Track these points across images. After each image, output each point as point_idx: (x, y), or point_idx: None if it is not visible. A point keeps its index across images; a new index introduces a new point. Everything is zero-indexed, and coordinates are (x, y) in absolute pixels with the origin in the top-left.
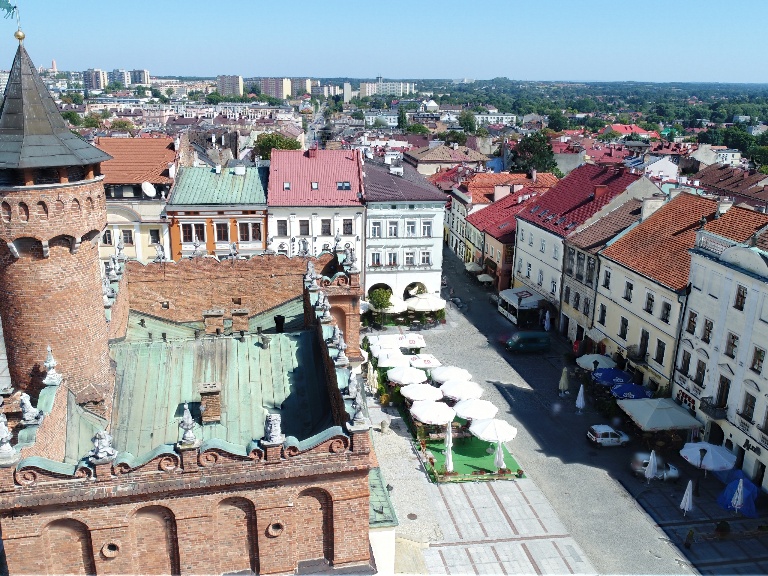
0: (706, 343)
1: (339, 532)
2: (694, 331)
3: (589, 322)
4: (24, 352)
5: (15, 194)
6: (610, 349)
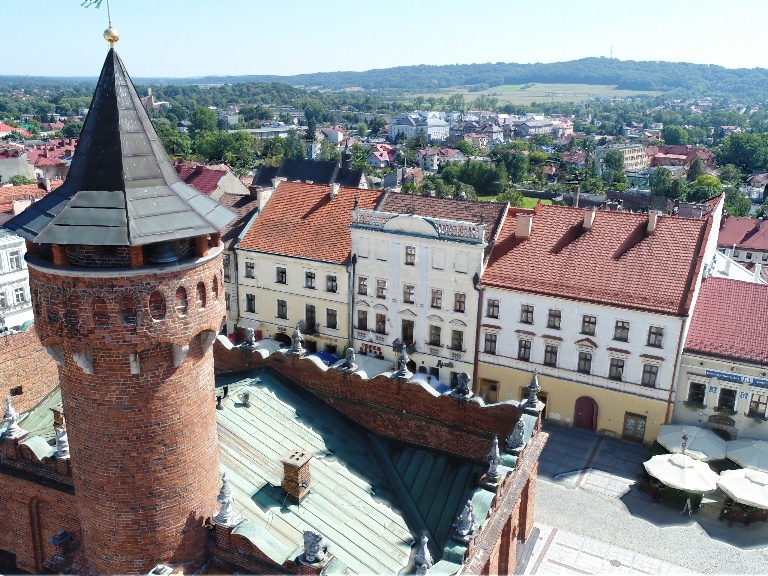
0: (383, 299)
1: (528, 509)
2: (367, 292)
3: (233, 315)
4: (175, 504)
5: (194, 272)
6: (268, 332)
